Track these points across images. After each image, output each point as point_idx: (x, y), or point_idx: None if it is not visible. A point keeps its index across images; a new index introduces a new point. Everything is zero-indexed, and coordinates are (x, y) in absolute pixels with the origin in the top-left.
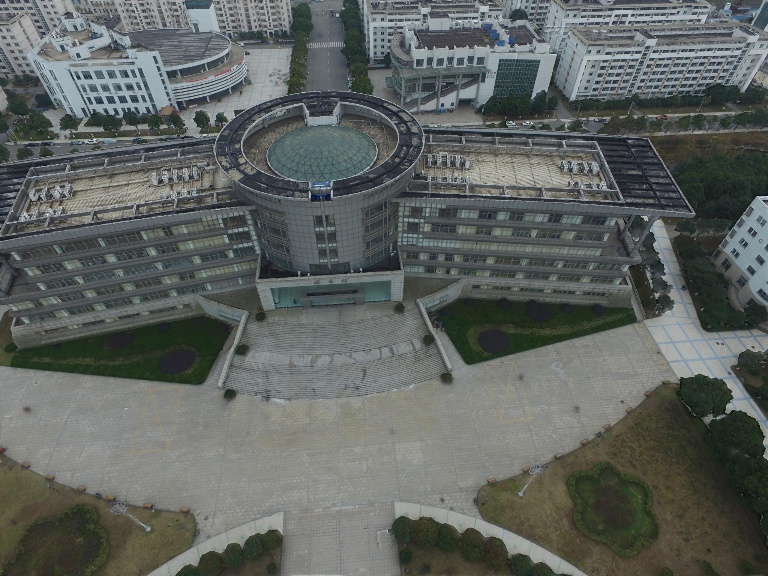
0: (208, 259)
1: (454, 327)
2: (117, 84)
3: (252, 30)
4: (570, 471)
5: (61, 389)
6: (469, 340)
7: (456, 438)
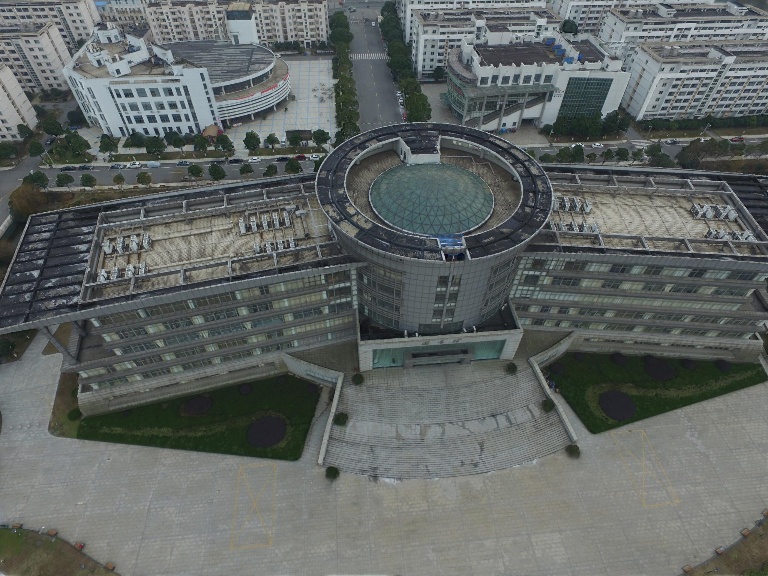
0: (301, 316)
1: (569, 388)
2: (160, 102)
3: (288, 40)
4: (737, 570)
5: (138, 467)
6: (589, 404)
7: (598, 528)
